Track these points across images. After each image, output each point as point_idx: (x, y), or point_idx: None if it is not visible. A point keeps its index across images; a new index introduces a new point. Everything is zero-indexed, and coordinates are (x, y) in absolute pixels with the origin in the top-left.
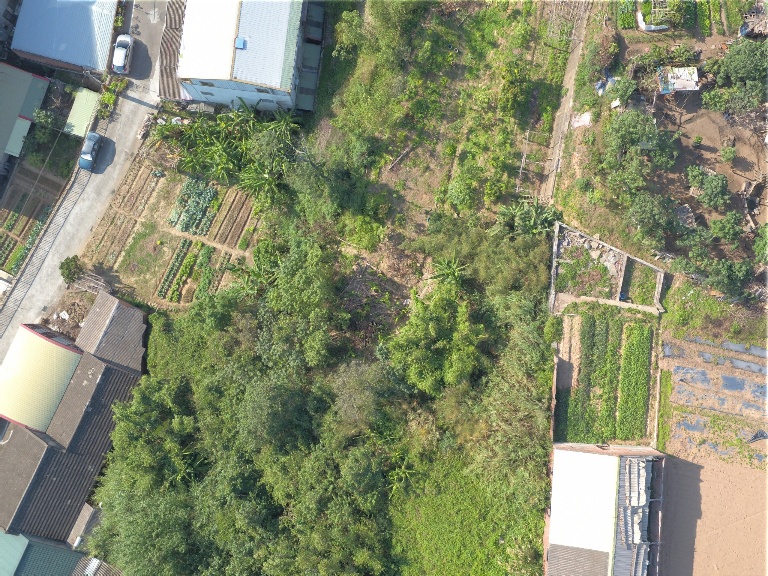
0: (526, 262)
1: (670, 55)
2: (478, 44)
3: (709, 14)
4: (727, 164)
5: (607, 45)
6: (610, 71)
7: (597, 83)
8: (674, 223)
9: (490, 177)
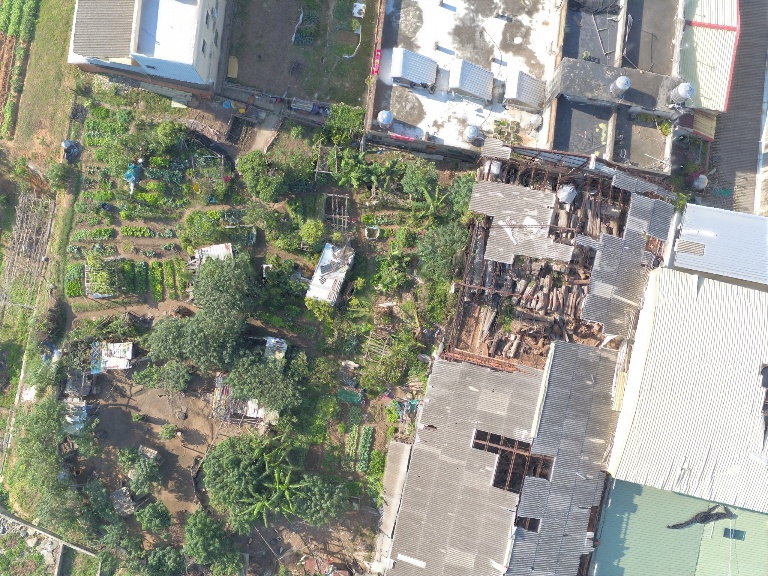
0: None
1: None
2: None
3: (161, 278)
4: (177, 438)
5: None
6: (55, 343)
7: (42, 356)
8: (106, 510)
9: None
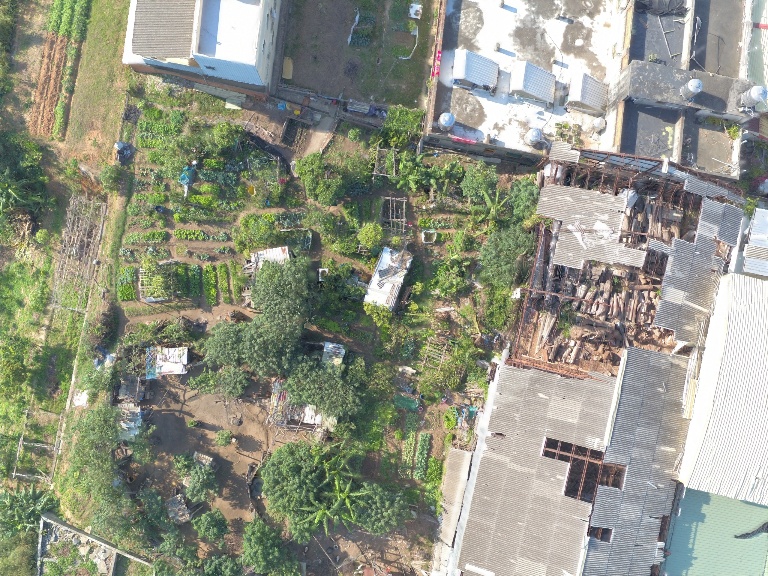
0: (5, 563)
1: (159, 335)
2: (7, 302)
3: (215, 282)
4: (232, 444)
5: (97, 323)
6: (108, 347)
7: (94, 360)
8: (161, 518)
9: (7, 450)
